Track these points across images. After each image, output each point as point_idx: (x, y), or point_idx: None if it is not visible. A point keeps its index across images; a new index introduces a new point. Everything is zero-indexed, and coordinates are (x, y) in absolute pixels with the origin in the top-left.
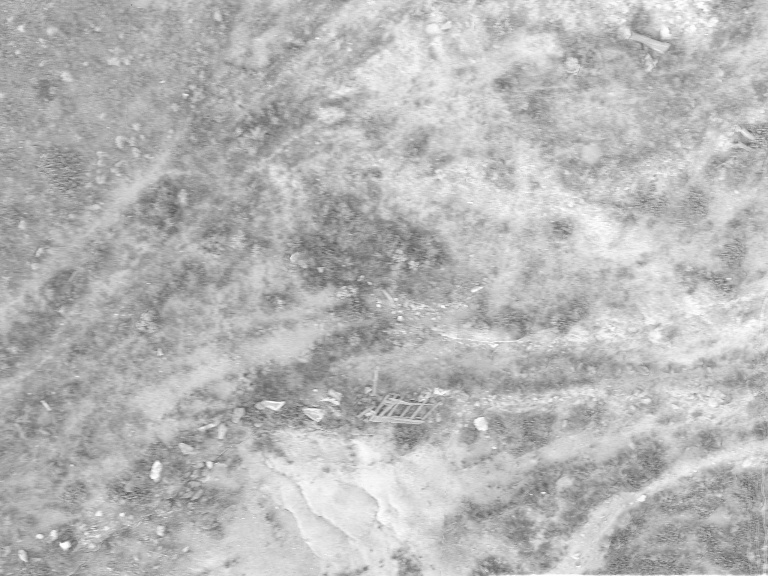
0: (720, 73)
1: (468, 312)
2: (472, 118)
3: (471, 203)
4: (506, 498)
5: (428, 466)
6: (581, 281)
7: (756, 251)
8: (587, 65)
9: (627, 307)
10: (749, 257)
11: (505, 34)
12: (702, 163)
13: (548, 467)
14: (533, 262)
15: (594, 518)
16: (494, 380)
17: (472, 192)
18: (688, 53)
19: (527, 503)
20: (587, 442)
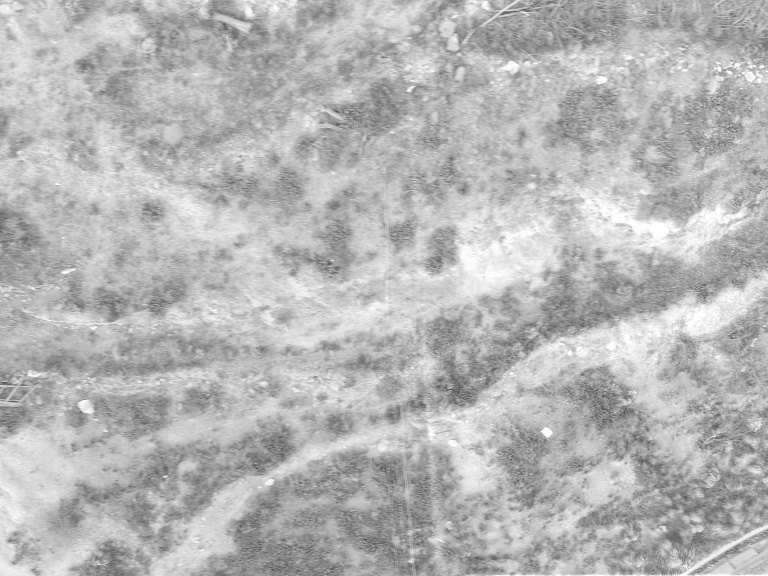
0: (302, 53)
1: (60, 294)
2: (53, 99)
3: (59, 185)
4: (125, 481)
5: (36, 449)
6: (177, 263)
7: (363, 233)
8: (170, 45)
9: (227, 289)
10: (356, 239)
11: (78, 14)
12: (290, 144)
13: (168, 450)
14: (126, 244)
15: (218, 502)
16: (94, 362)
17: (58, 173)
18: (271, 33)
19: (148, 487)
20: (210, 425)
